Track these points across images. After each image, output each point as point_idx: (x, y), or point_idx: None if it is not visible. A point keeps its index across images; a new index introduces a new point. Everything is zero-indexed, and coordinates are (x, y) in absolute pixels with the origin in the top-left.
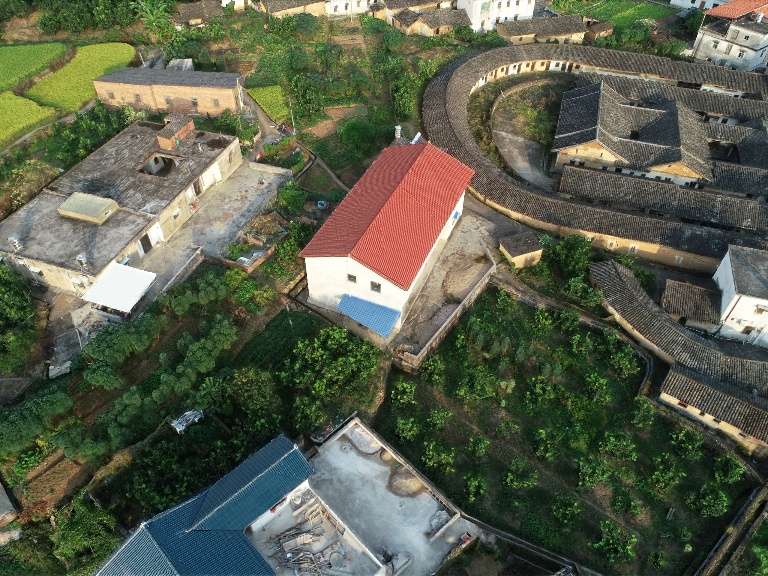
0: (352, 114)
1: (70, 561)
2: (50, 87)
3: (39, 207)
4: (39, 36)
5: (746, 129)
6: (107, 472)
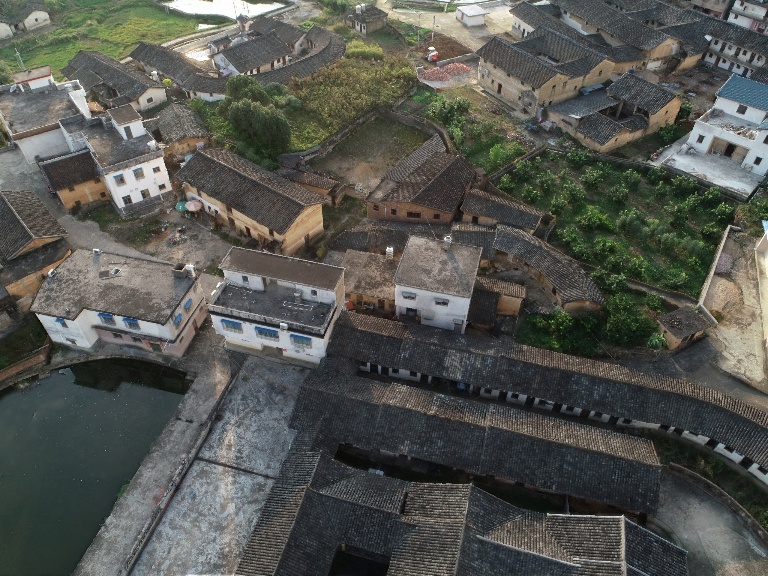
0: None
1: None
2: None
3: None
4: None
5: None
6: None
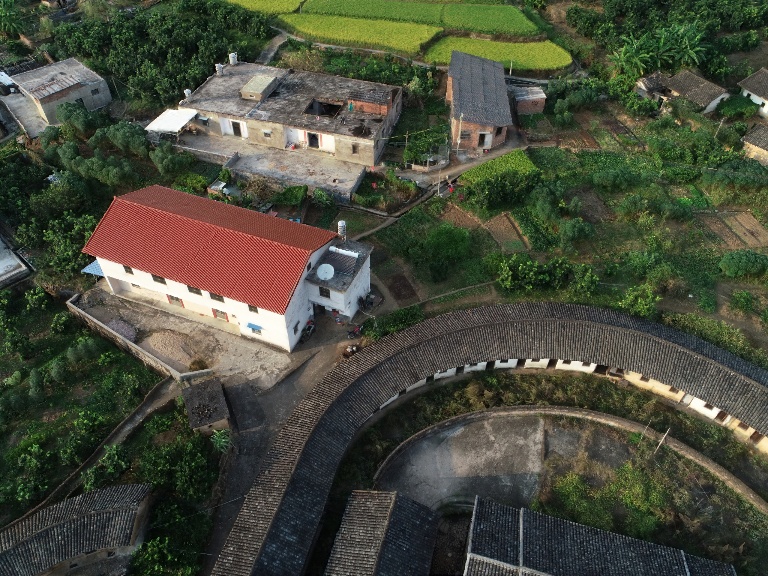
0: (501, 238)
1: None
2: (462, 44)
3: (269, 72)
4: (563, 21)
5: None
6: None
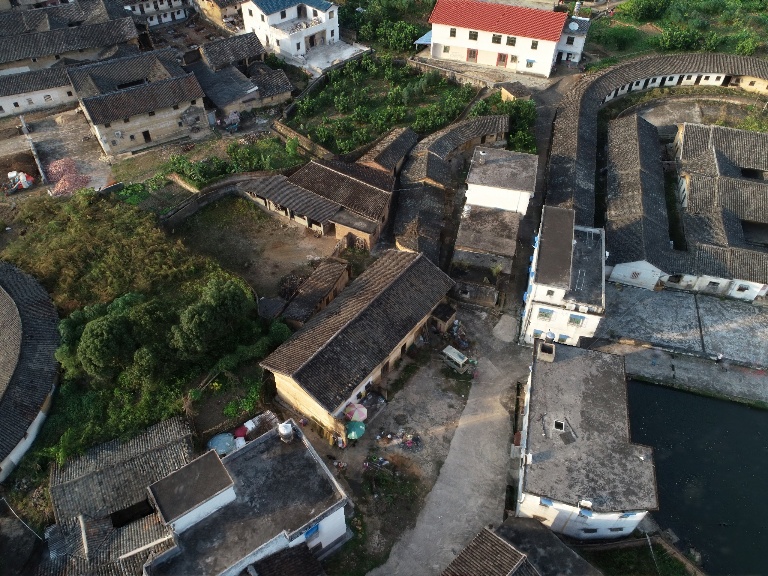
0: (651, 33)
1: None
2: None
3: None
4: None
5: None
6: (337, 1)
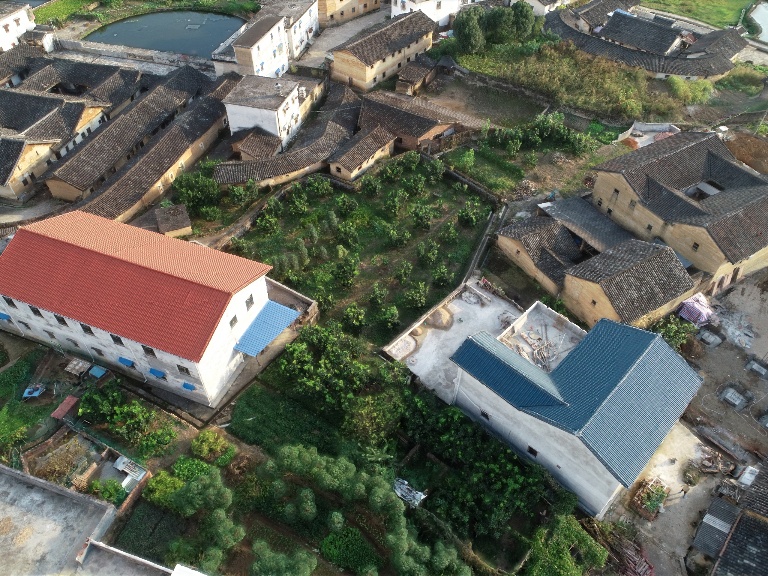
0: None
1: (584, 575)
2: None
3: None
4: None
5: (47, 69)
6: None
